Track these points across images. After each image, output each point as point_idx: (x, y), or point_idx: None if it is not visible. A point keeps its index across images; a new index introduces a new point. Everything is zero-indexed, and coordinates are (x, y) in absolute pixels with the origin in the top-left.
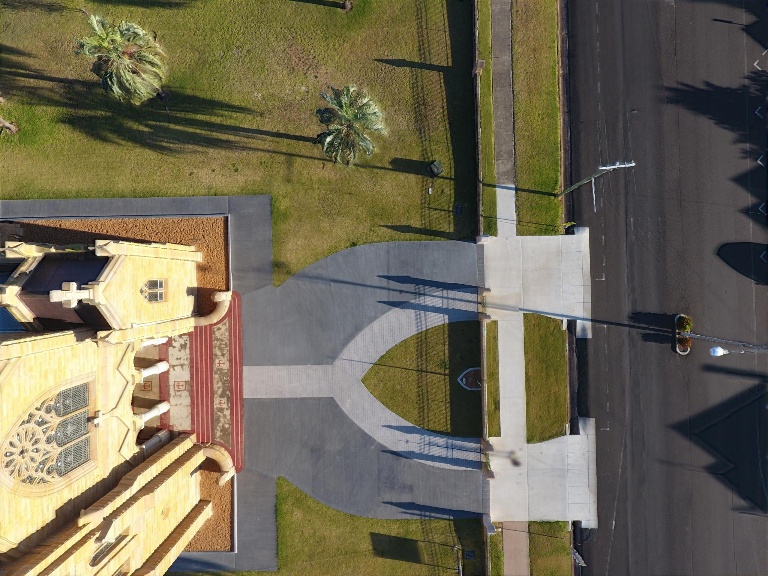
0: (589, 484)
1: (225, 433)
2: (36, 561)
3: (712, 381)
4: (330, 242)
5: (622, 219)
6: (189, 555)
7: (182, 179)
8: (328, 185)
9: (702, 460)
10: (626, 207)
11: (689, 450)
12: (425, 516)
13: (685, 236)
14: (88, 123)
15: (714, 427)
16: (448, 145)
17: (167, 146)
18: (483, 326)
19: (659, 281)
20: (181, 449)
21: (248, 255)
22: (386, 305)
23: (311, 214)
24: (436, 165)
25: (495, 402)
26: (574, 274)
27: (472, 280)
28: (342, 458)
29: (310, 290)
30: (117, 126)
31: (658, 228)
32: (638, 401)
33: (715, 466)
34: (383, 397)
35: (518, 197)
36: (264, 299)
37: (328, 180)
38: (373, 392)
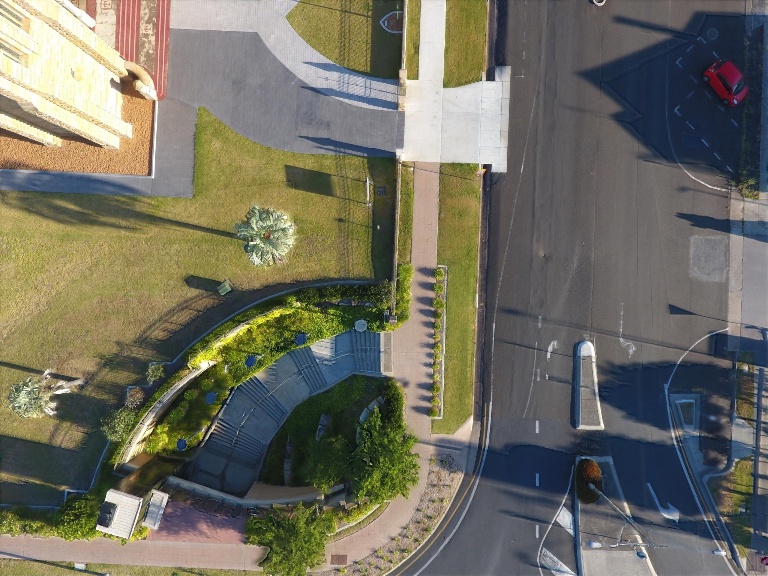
0: (501, 129)
1: (149, 58)
2: None
3: (626, 33)
4: None
5: None
6: (107, 178)
7: None
8: None
9: (611, 108)
10: None
11: (599, 98)
12: (340, 152)
13: None
14: None
15: (625, 77)
16: None
17: None
18: None
19: None
20: None
21: None
22: None
23: None
24: None
25: (415, 47)
26: None
27: None
28: (262, 92)
29: None
30: None
31: None
32: (553, 50)
33: (623, 115)
34: (306, 34)
35: None
36: None
37: None
38: (296, 29)
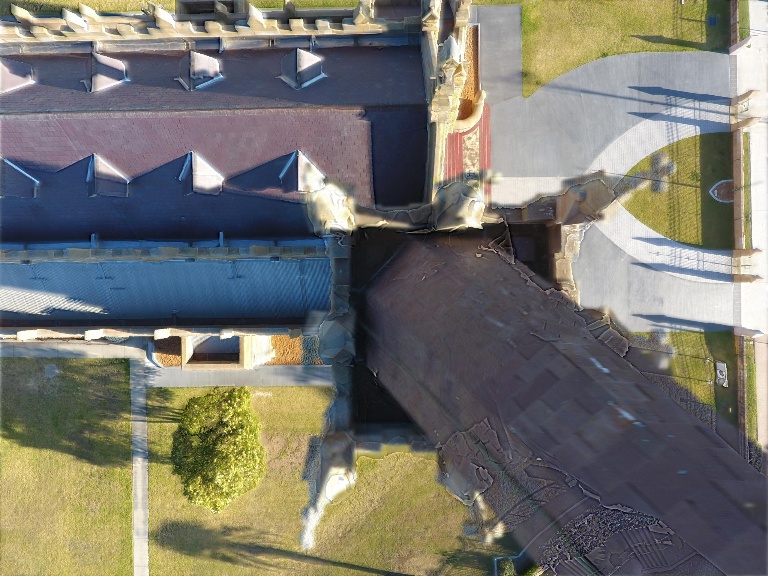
0: None
1: None
2: None
3: None
4: (580, 52)
5: None
6: None
7: None
8: None
9: None
10: None
11: None
12: (676, 329)
13: None
14: None
15: None
16: None
17: None
18: (741, 134)
19: None
20: None
21: (497, 65)
22: (637, 116)
23: (562, 24)
24: None
25: (746, 215)
26: None
27: (724, 91)
28: (591, 271)
29: (560, 101)
30: None
31: None
32: None
33: None
34: (634, 209)
35: None
36: (513, 110)
37: None
38: (624, 204)
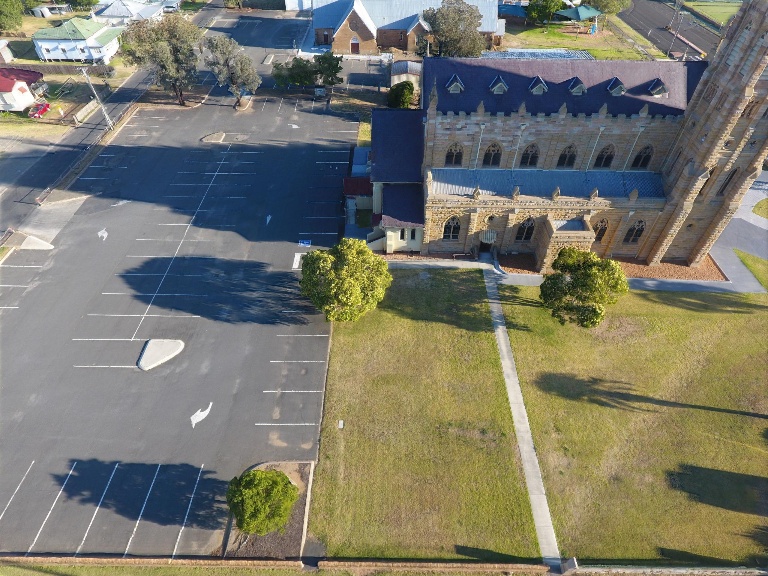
0: None
1: None
2: None
3: None
4: None
5: None
6: (699, 283)
7: None
8: None
9: None
10: None
11: None
12: None
13: None
14: None
15: None
16: None
17: None
18: None
19: None
20: None
21: None
22: None
23: None
24: None
25: None
26: None
27: None
28: (767, 242)
29: None
30: None
31: None
32: None
33: None
34: None
35: None
36: None
37: None
38: None
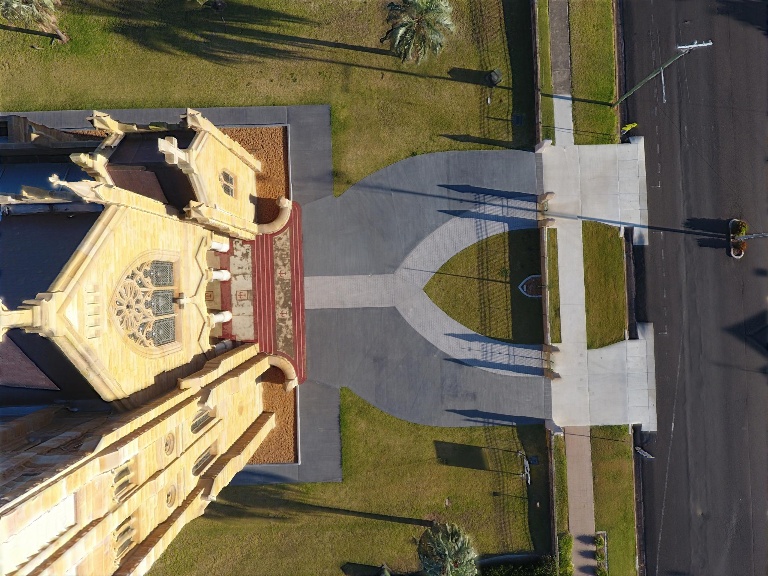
0: (648, 387)
1: (287, 344)
2: (154, 405)
3: (765, 284)
4: (390, 152)
5: (676, 128)
6: (252, 468)
7: (240, 89)
8: (387, 95)
9: (757, 361)
10: (680, 116)
11: (744, 351)
12: (488, 423)
13: (737, 143)
14: (142, 33)
15: (767, 328)
16: (506, 55)
17: (224, 56)
18: (544, 232)
19: (713, 187)
20: (249, 353)
21: (308, 165)
22: (447, 214)
23: (371, 124)
24: (496, 72)
25: (555, 309)
26: (630, 182)
27: (531, 188)
28: (405, 367)
29: (371, 200)
30: (172, 36)
31: (711, 136)
32: (695, 305)
33: None
34: (445, 305)
35: (575, 107)
36: (324, 209)
37: (387, 90)
38: (435, 301)
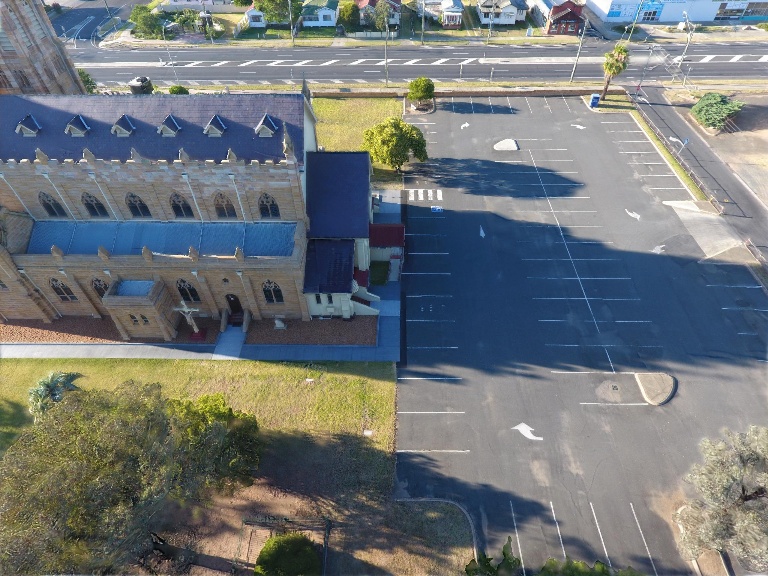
0: None
1: None
2: None
3: None
4: None
5: None
6: None
7: None
8: None
9: None
10: None
11: None
12: None
13: None
14: (24, 421)
15: None
16: None
17: None
18: None
19: None
20: None
21: None
22: None
23: None
24: None
25: None
26: None
27: None
28: None
29: None
30: None
31: None
32: None
33: None
34: None
35: None
36: None
37: None
38: None
